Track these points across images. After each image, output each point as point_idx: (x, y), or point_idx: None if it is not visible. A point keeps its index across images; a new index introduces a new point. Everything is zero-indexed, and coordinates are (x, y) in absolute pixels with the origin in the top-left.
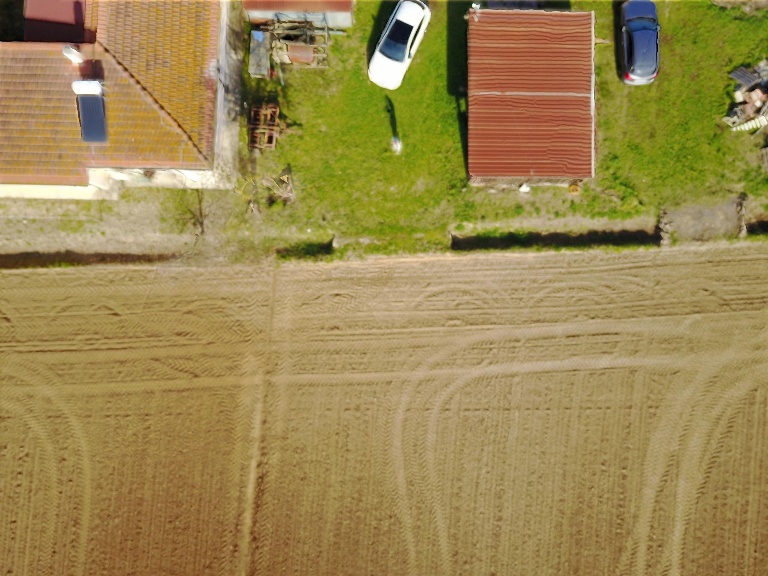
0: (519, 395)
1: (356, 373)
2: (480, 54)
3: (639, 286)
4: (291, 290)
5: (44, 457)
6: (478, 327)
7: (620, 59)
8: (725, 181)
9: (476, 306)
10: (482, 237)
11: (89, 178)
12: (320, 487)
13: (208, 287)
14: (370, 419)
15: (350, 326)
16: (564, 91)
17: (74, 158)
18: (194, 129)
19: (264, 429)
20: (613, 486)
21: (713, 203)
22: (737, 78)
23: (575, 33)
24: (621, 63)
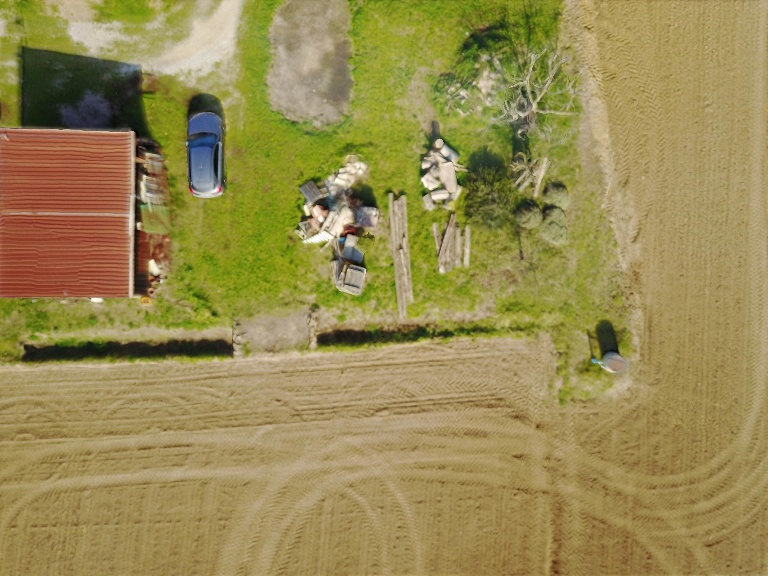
0: (87, 510)
1: None
2: (12, 174)
3: (213, 397)
4: None
5: None
6: (48, 441)
7: None
8: (297, 292)
9: (47, 419)
10: (59, 347)
11: None
12: None
13: None
14: None
15: None
16: (100, 212)
17: None
18: None
19: None
20: None
21: (286, 314)
22: (305, 192)
23: (115, 153)
24: None
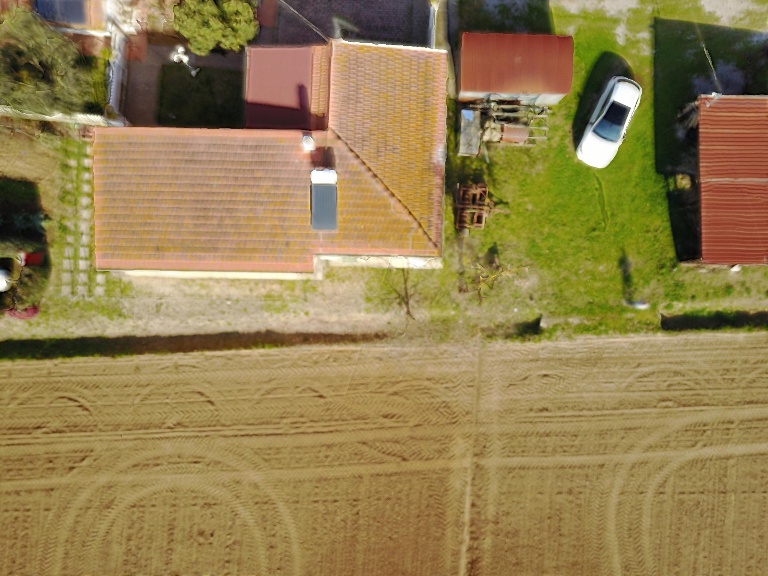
0: (734, 478)
1: (567, 456)
2: (711, 140)
3: None
4: (497, 370)
5: (250, 544)
6: (691, 408)
7: None
8: None
9: (688, 387)
10: (690, 316)
11: None
12: (533, 573)
13: (412, 367)
14: (582, 503)
15: (559, 407)
16: None
17: (302, 245)
18: (424, 216)
19: (472, 513)
20: None
21: None
22: None
23: None
24: None
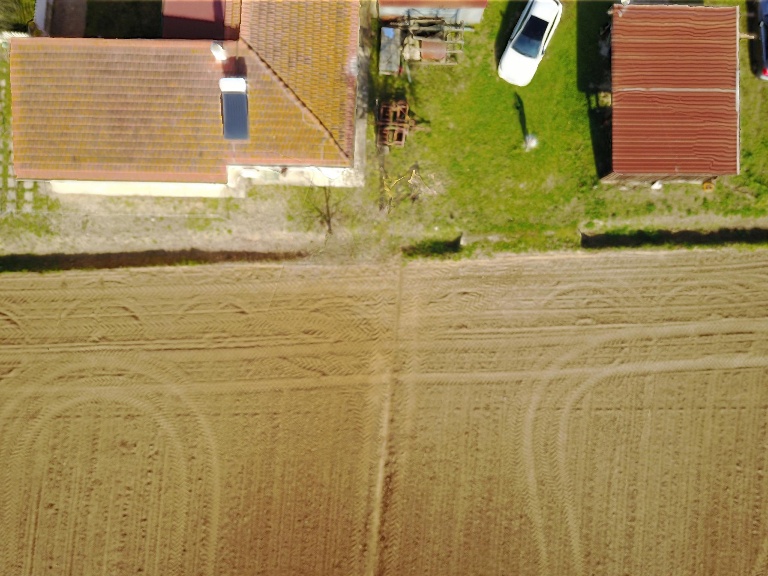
0: (652, 394)
1: (485, 372)
2: (624, 50)
3: None
4: (418, 288)
5: (173, 455)
6: (609, 326)
7: (756, 55)
8: None
9: (607, 305)
10: (611, 235)
11: (227, 176)
12: (450, 486)
13: (334, 285)
14: (500, 418)
15: (479, 325)
16: (709, 87)
17: (215, 156)
18: (335, 126)
19: (392, 428)
20: (749, 487)
21: None
22: None
23: (719, 28)
24: (757, 59)
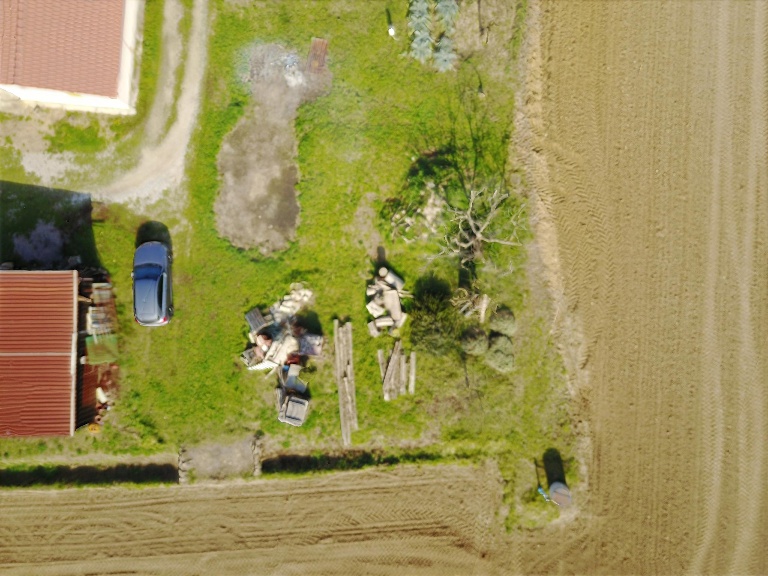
0: None
1: None
2: None
3: (159, 523)
4: None
5: None
6: None
7: None
8: (243, 419)
9: None
10: (11, 471)
11: None
12: None
13: None
14: None
15: None
16: (42, 351)
17: None
18: None
19: None
20: None
21: (231, 440)
22: (249, 320)
23: (58, 291)
24: None
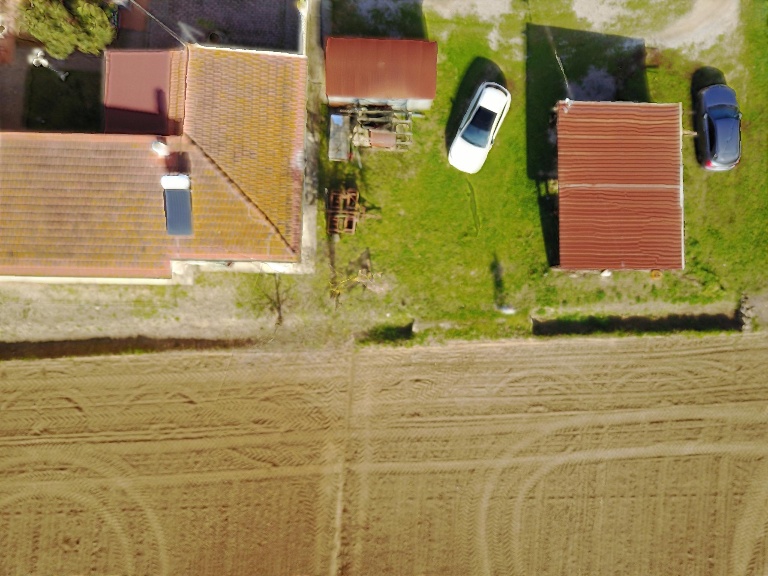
0: (603, 482)
1: (438, 461)
2: (570, 146)
3: (721, 371)
4: (370, 376)
5: (117, 552)
6: (561, 413)
7: (701, 145)
8: None
9: (558, 392)
10: (562, 321)
11: None
12: None
13: (285, 373)
14: (452, 508)
15: (431, 412)
16: (654, 183)
17: (158, 251)
18: (282, 221)
19: (343, 519)
20: (700, 575)
21: None
22: None
23: (663, 124)
24: (702, 149)
